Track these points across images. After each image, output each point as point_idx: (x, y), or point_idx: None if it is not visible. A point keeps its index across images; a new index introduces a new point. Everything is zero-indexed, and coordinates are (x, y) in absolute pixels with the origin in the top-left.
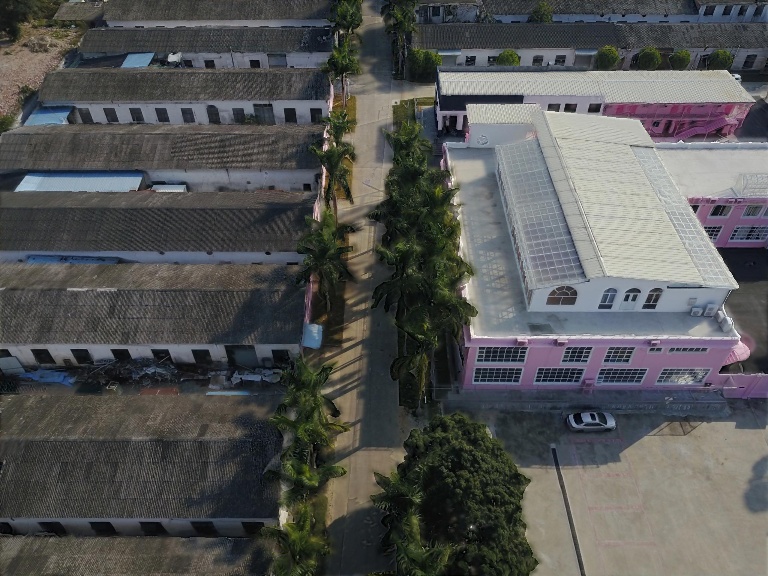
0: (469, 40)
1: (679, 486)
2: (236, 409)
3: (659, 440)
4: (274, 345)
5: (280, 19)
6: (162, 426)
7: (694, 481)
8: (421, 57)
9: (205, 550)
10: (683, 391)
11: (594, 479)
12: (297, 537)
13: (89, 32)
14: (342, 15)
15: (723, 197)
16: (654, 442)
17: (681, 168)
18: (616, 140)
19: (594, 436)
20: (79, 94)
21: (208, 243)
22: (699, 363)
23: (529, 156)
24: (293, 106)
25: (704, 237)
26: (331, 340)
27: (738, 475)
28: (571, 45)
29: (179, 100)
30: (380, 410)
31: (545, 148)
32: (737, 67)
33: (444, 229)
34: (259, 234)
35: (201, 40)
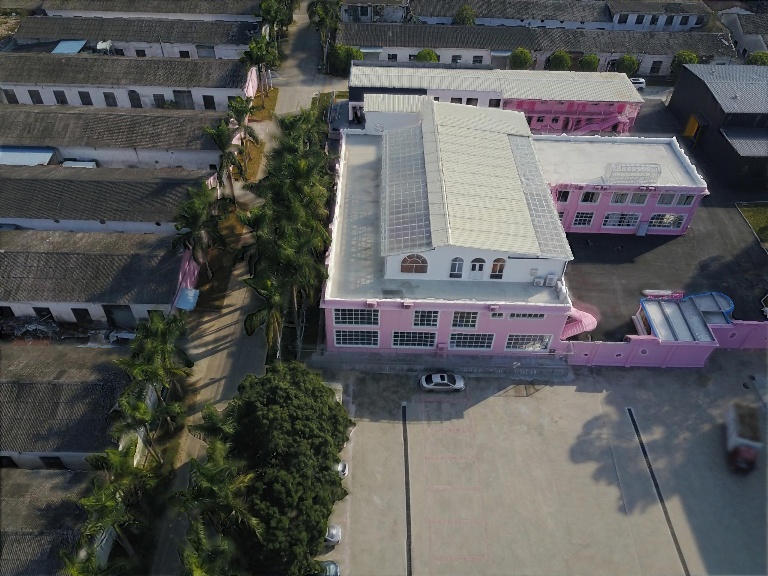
0: (391, 38)
1: (512, 440)
2: (97, 358)
3: (502, 400)
4: (148, 305)
5: (214, 13)
6: (22, 371)
7: (527, 436)
8: (342, 53)
9: (45, 480)
10: (531, 357)
11: (436, 433)
12: (117, 461)
13: (24, 19)
14: (266, 10)
15: (590, 184)
16: (498, 402)
17: (560, 158)
18: (495, 129)
19: (443, 396)
20: (4, 76)
21: (101, 213)
22: (540, 329)
23: (411, 141)
24: (211, 93)
25: (554, 215)
26: (212, 306)
27: (568, 432)
28: (487, 46)
29: (101, 84)
30: (246, 368)
31: (426, 134)
32: (645, 72)
33: (305, 199)
34: (151, 206)
35: (133, 30)
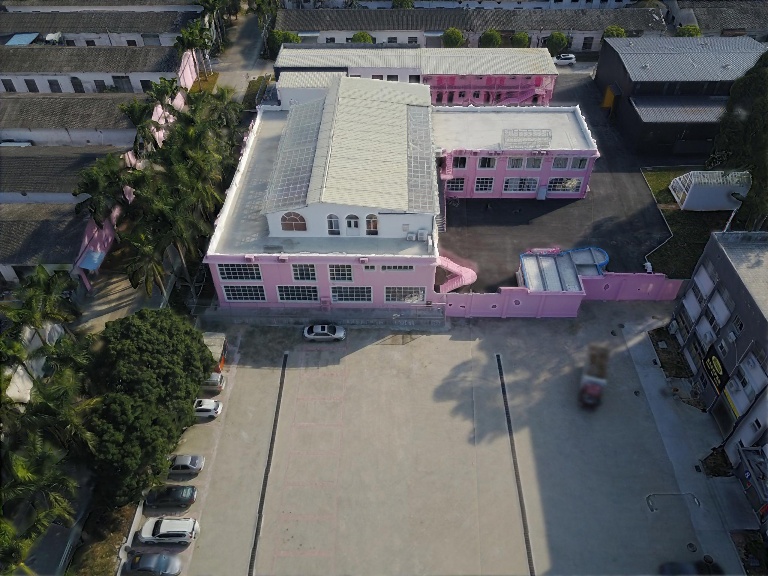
0: (328, 23)
1: (380, 383)
2: None
3: (379, 348)
4: (53, 265)
5: (163, 5)
6: None
7: (395, 379)
8: (280, 37)
9: None
10: (411, 309)
11: (311, 377)
12: None
13: None
14: None
15: (484, 149)
16: (374, 350)
17: (463, 127)
18: (396, 100)
19: (324, 345)
20: None
21: (22, 185)
22: (414, 281)
23: (313, 112)
24: (148, 78)
25: (432, 176)
26: (121, 268)
27: (435, 375)
28: (420, 27)
29: (44, 72)
30: None
31: (327, 106)
32: (577, 49)
33: None
34: (68, 178)
35: (83, 22)
